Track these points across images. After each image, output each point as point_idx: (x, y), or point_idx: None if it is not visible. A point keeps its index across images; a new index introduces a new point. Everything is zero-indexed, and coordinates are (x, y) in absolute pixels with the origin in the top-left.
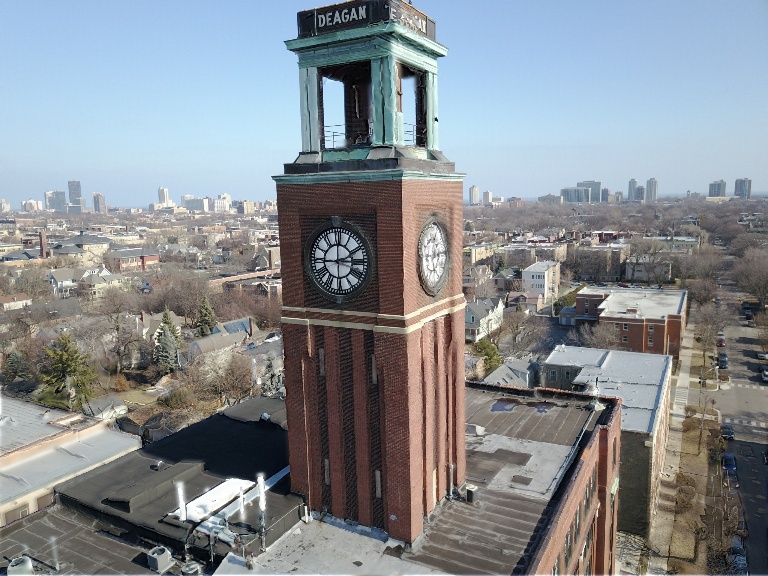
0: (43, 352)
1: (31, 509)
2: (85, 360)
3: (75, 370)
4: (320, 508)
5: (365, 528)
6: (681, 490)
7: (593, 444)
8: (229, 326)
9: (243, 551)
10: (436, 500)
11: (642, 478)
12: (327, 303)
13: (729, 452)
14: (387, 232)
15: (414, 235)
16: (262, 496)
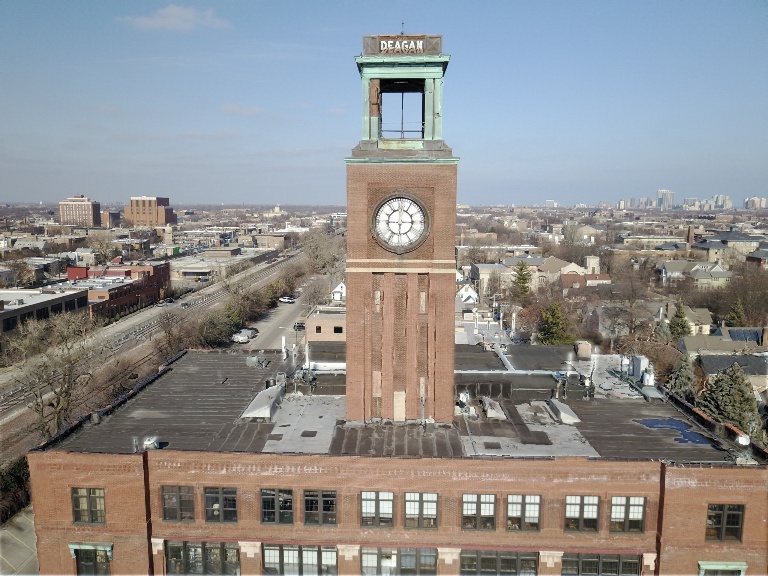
0: (540, 313)
1: None
2: (563, 326)
3: (555, 332)
4: None
5: None
6: None
7: (619, 465)
8: (739, 332)
9: (295, 387)
10: (405, 417)
11: None
12: None
13: None
14: None
15: (368, 205)
16: (307, 360)
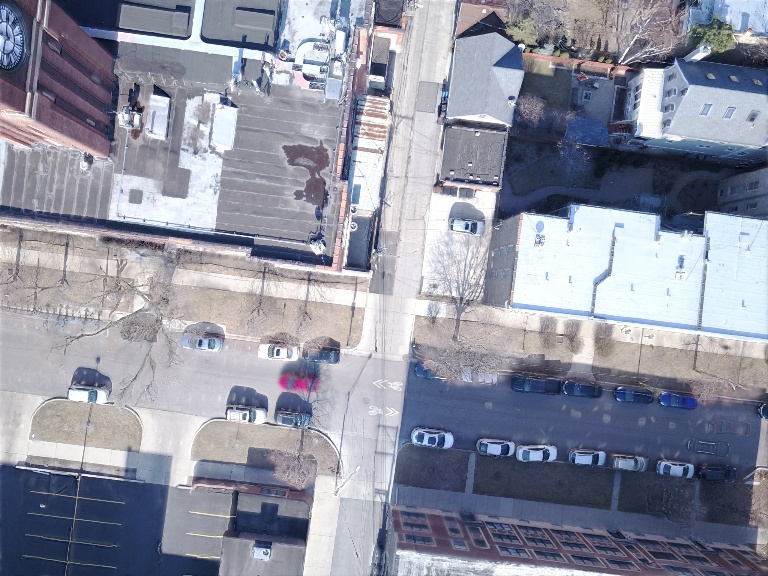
0: None
1: None
2: None
3: None
4: None
5: None
6: (572, 340)
7: None
8: None
9: None
10: None
11: None
12: None
13: (713, 406)
14: None
15: None
16: None
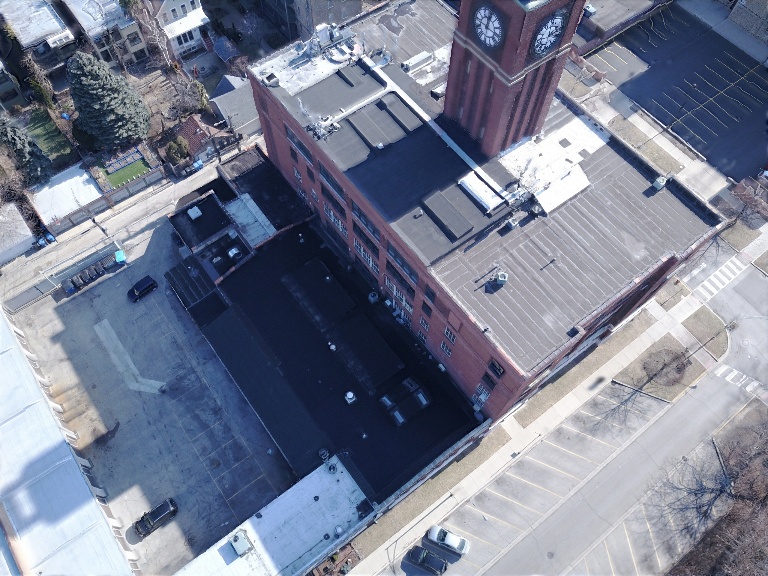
0: None
1: (55, 408)
2: None
3: None
4: None
5: (519, 143)
6: None
7: None
8: None
9: None
10: None
11: (358, 2)
12: None
13: None
14: (579, 6)
15: None
16: None
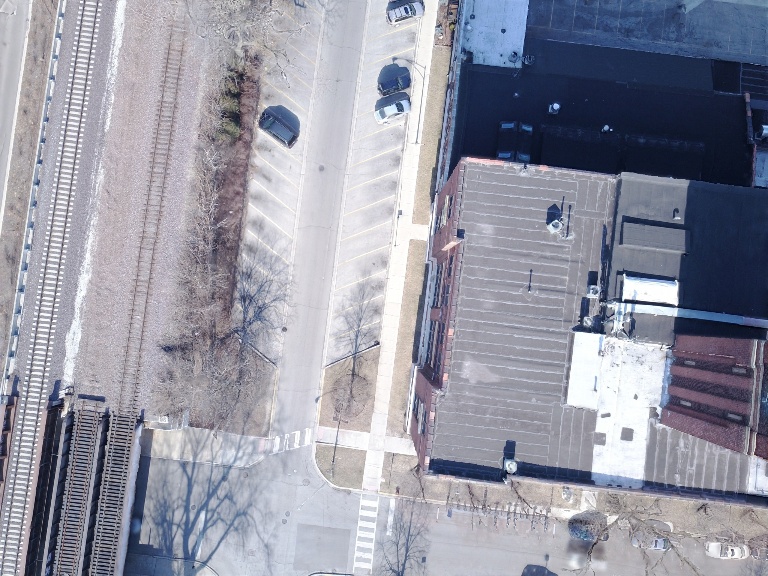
0: None
1: None
2: None
3: None
4: (674, 355)
5: (667, 390)
6: None
7: None
8: None
9: None
10: None
11: None
12: (765, 386)
13: None
14: None
15: None
16: None
